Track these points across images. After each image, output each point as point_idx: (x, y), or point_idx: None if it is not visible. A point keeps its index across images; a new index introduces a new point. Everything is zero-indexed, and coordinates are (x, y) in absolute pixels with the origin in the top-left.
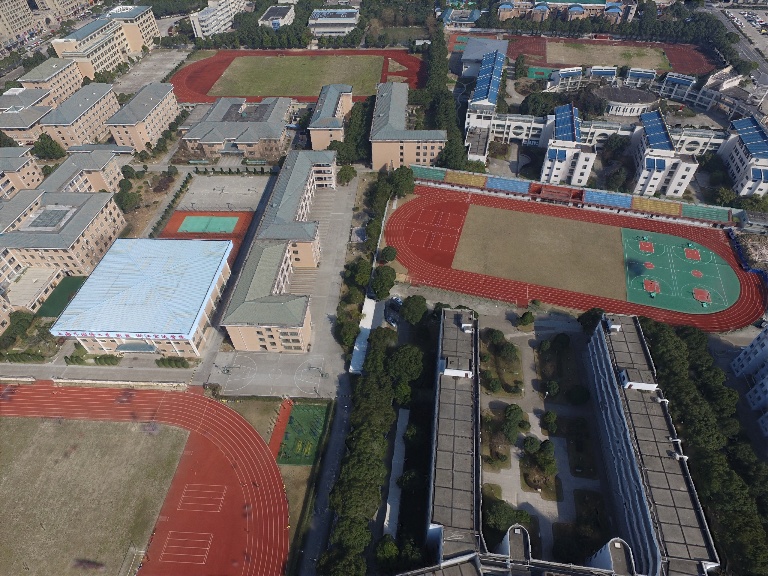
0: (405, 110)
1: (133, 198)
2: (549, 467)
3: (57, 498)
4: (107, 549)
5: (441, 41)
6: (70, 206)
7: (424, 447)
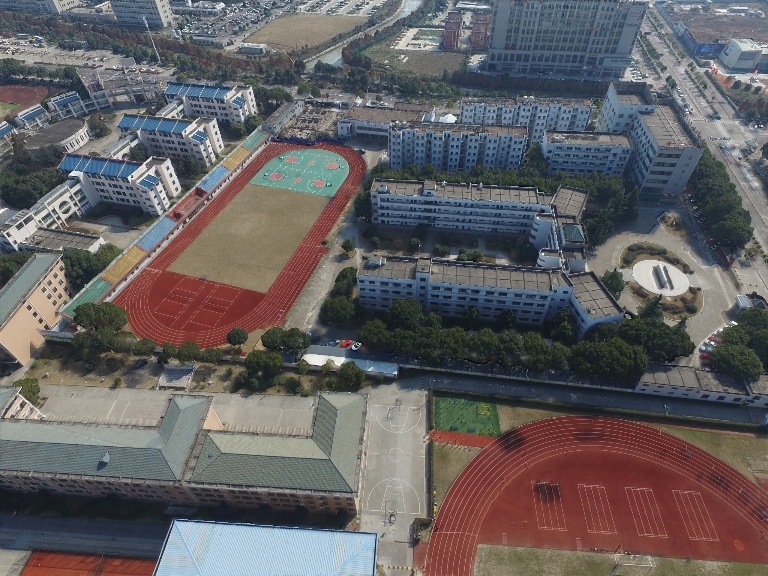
0: None
1: None
2: None
3: None
4: None
5: None
6: None
7: None
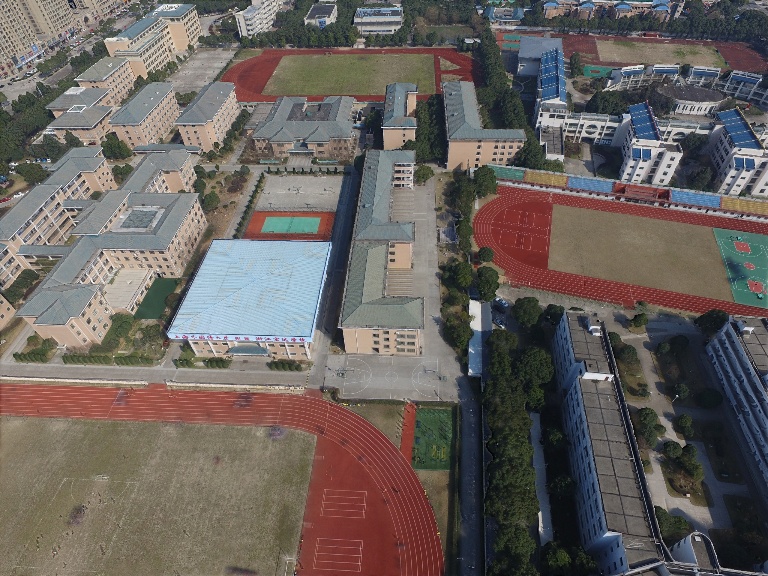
0: (477, 109)
1: (215, 198)
2: (697, 472)
3: (195, 504)
4: (257, 556)
5: (492, 39)
6: (158, 207)
7: (561, 451)
